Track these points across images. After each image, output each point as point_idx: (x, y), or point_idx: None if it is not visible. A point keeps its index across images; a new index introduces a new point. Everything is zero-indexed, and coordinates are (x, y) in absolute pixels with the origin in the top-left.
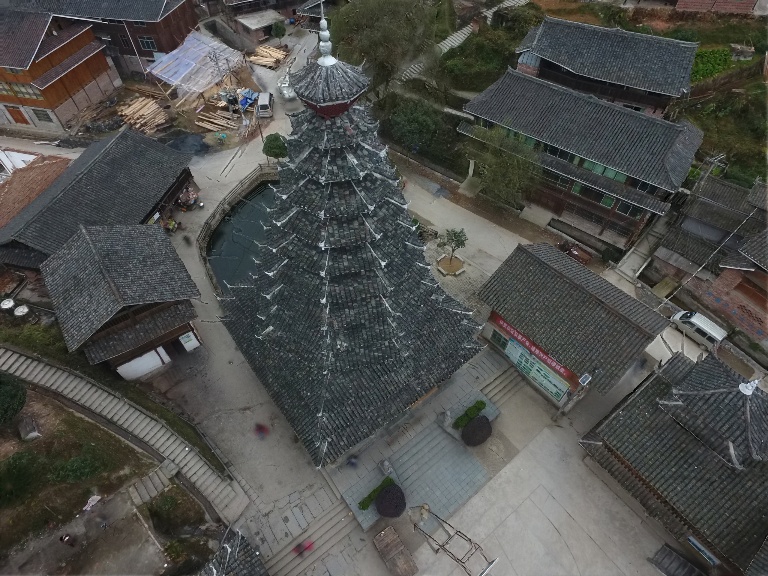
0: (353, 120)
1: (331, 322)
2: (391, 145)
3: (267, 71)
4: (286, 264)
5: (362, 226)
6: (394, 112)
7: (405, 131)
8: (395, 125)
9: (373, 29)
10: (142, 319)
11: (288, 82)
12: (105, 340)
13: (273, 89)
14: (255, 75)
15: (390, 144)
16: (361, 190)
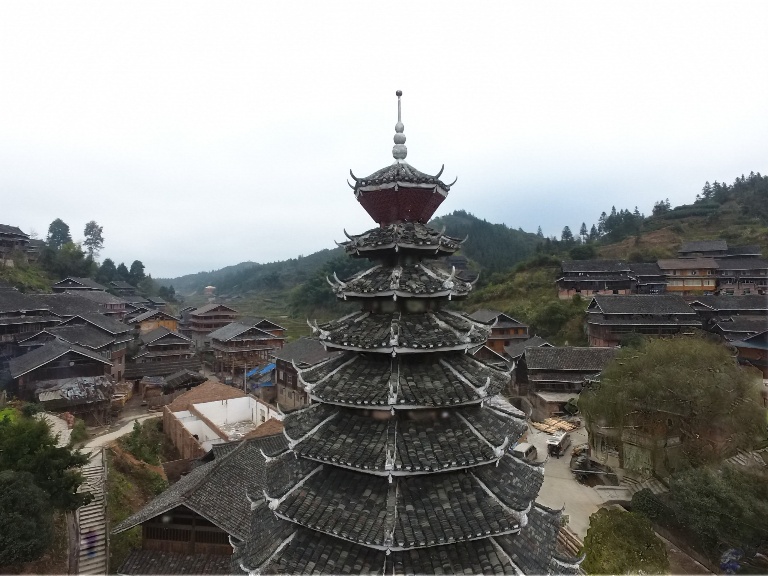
0: (413, 229)
1: (272, 571)
2: (689, 551)
3: (546, 436)
4: (292, 452)
5: (382, 384)
6: (677, 476)
7: (690, 503)
8: (674, 491)
9: (652, 372)
10: (200, 552)
11: (559, 441)
12: (153, 553)
13: (543, 449)
14: (531, 436)
15: (688, 549)
16: (395, 321)
